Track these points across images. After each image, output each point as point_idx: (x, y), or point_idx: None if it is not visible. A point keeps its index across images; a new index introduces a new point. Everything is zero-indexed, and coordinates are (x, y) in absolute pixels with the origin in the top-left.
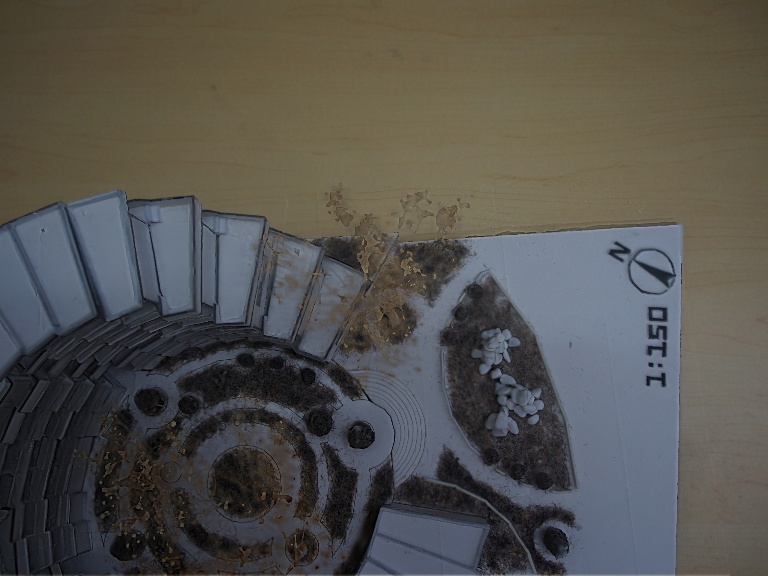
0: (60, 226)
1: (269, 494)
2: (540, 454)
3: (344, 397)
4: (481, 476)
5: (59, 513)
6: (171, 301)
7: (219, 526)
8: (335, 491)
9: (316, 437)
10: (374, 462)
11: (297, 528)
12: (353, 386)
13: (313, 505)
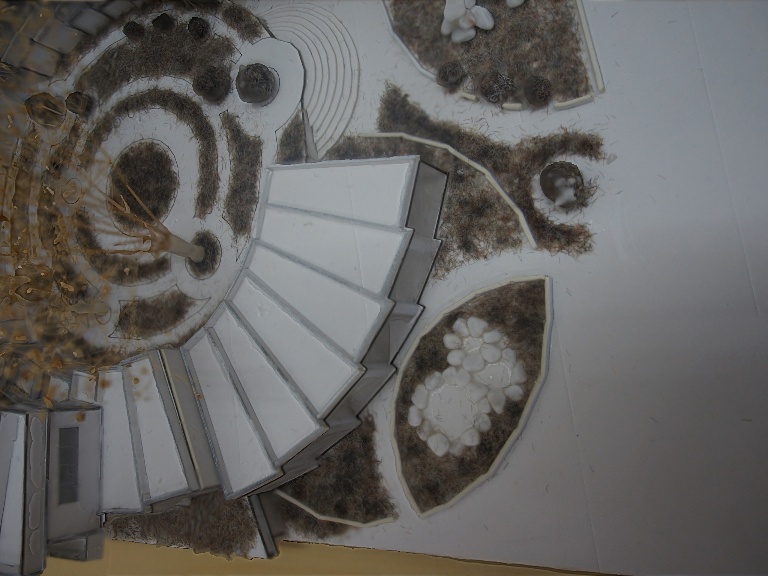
0: None
1: (165, 193)
2: (533, 52)
3: (242, 43)
4: (442, 113)
5: None
6: None
7: None
8: (236, 171)
9: (214, 107)
10: (280, 120)
11: (197, 231)
12: (250, 23)
13: (212, 196)
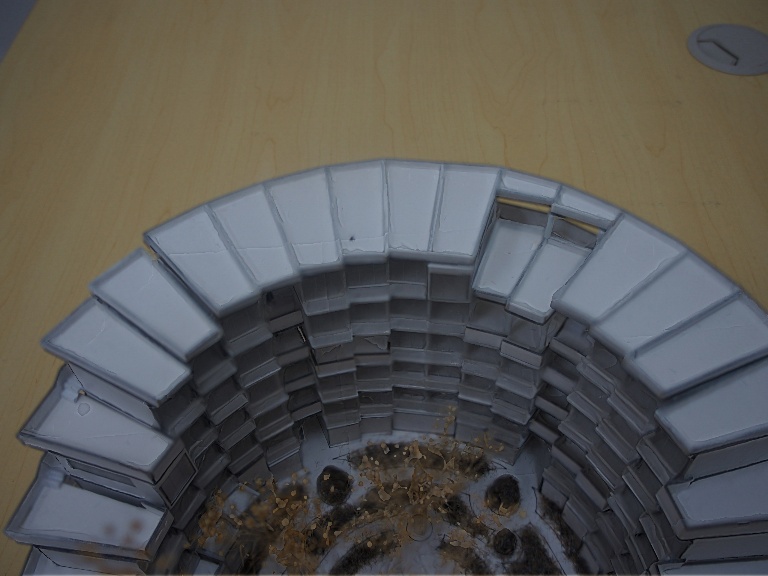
0: (760, 345)
1: None
2: None
3: None
4: None
5: (374, 406)
6: (685, 496)
7: None
8: None
9: None
10: None
11: None
12: None
13: None
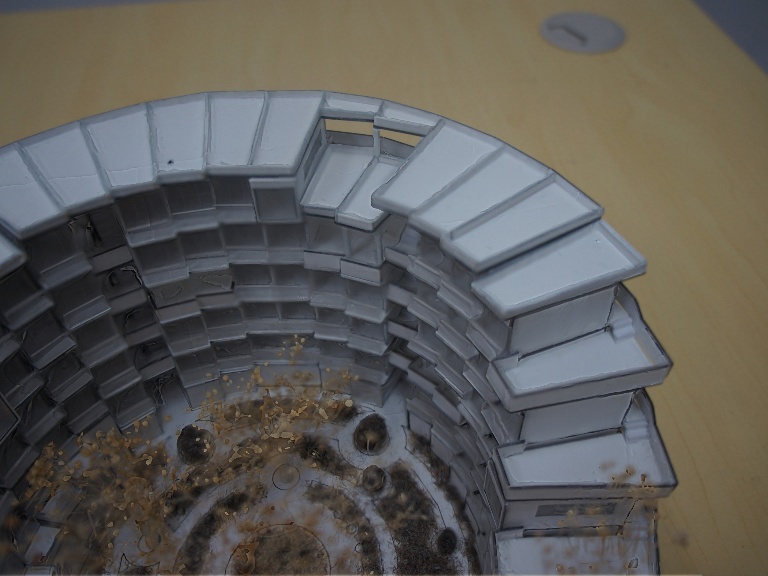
0: None
1: None
2: None
3: None
4: None
5: (232, 358)
6: (515, 373)
7: (219, 552)
8: None
9: None
10: None
11: None
12: None
13: None
